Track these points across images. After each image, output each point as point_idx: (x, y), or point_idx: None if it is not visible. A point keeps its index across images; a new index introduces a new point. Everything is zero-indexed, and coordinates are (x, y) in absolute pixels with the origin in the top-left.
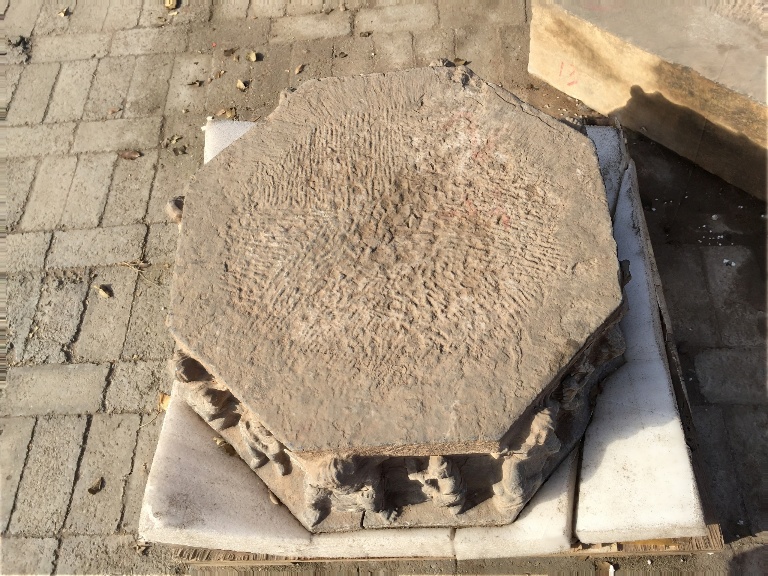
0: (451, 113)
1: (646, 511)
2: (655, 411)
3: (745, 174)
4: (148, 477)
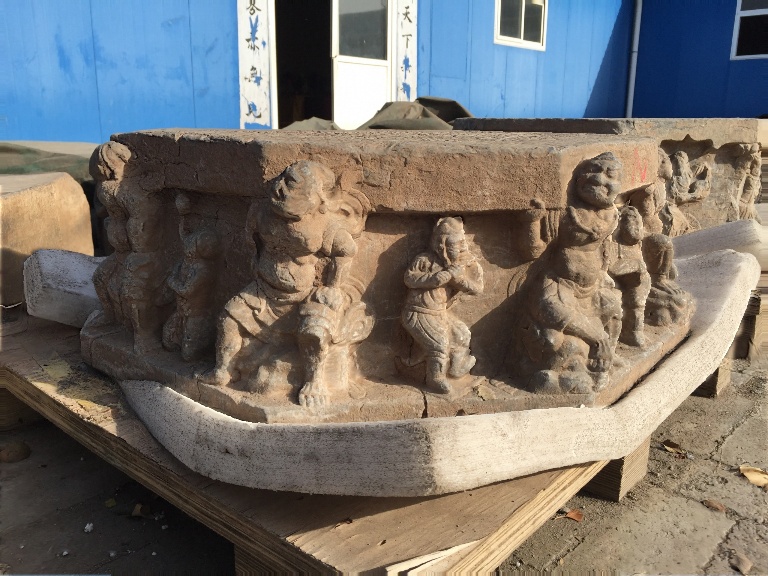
0: None
1: None
2: None
3: (2, 296)
4: (744, 271)
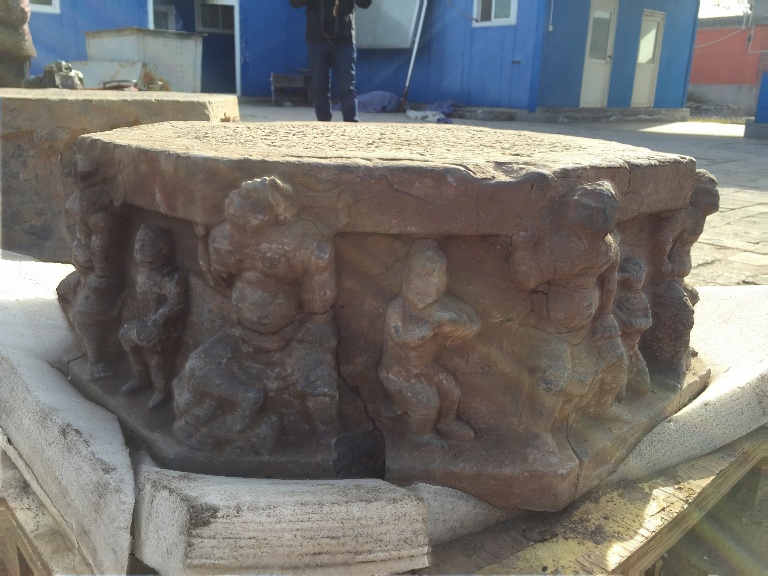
0: (461, 155)
1: (8, 265)
2: (3, 307)
3: None
4: None
